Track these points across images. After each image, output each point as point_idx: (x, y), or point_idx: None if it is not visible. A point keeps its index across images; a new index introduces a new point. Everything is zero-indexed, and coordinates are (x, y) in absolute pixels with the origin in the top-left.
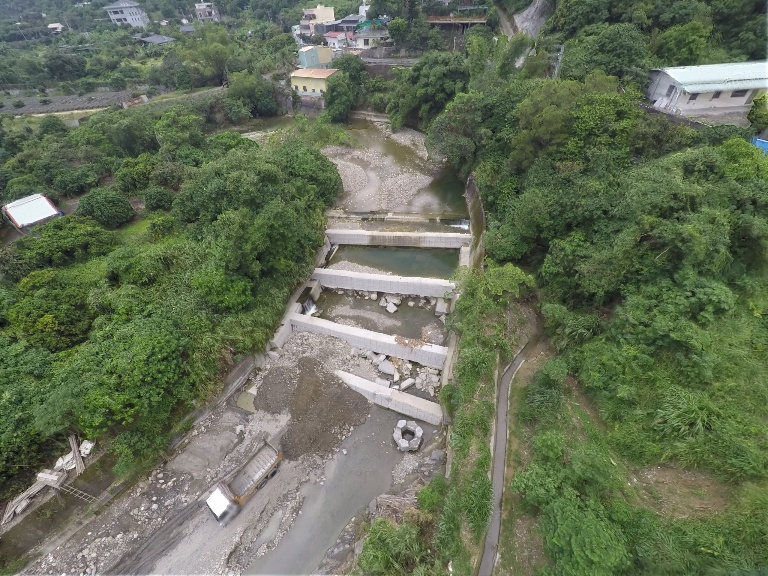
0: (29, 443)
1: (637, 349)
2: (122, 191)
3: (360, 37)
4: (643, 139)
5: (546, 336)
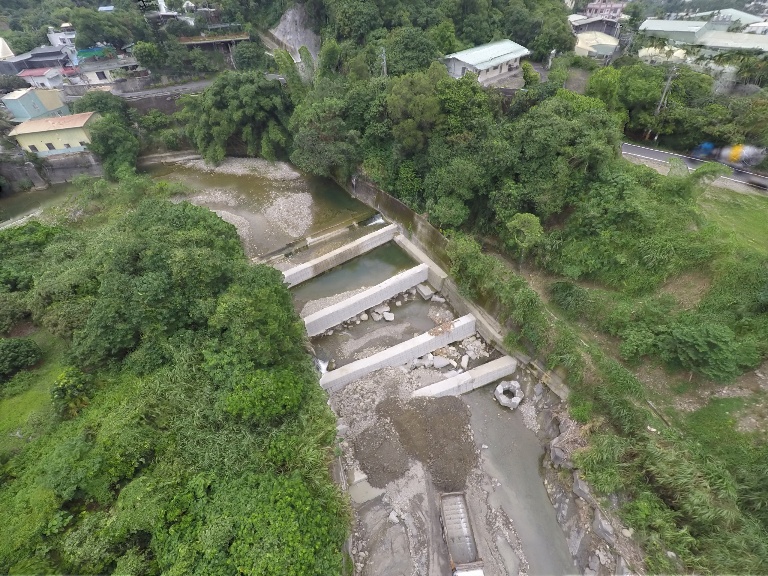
0: None
1: (610, 230)
2: None
3: (88, 70)
4: (497, 104)
5: (520, 264)
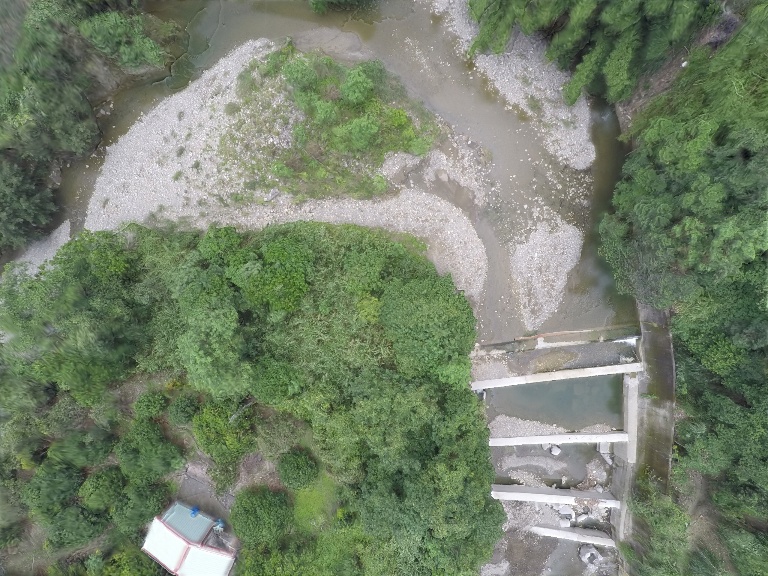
0: None
1: None
2: None
3: None
4: None
5: None
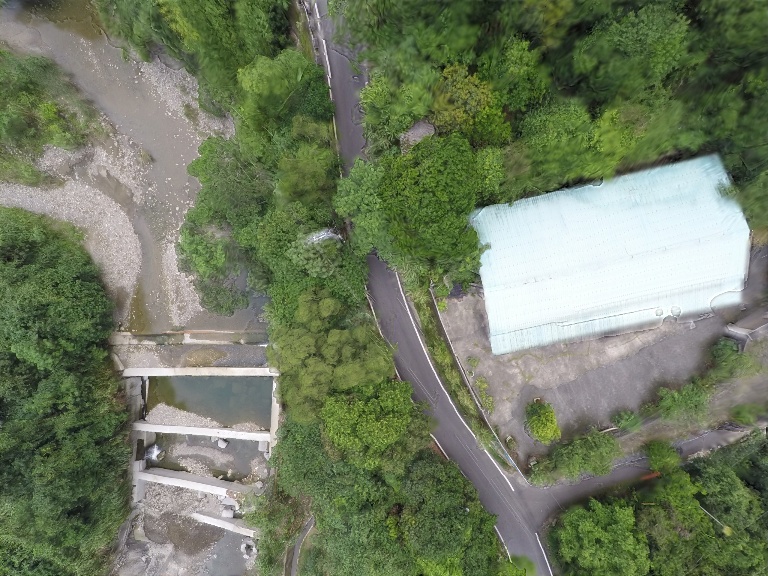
0: None
1: None
2: None
3: None
4: None
5: None
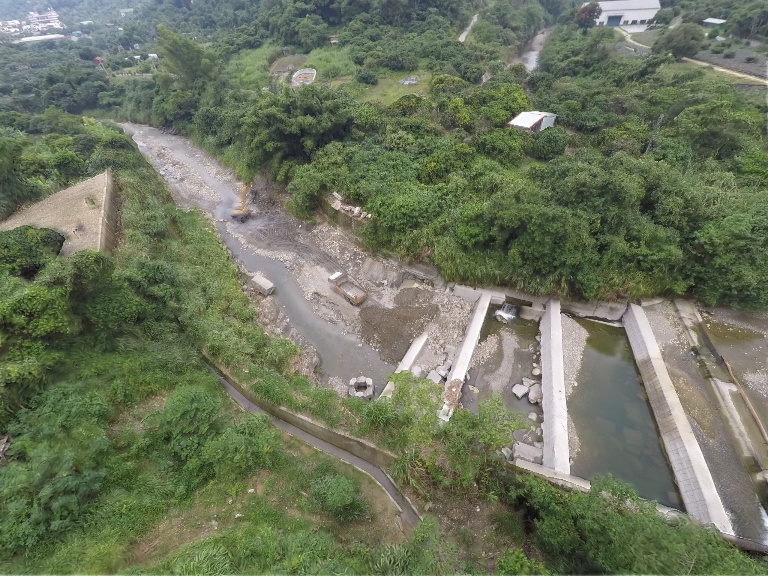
0: None
1: (295, 569)
2: (590, 143)
3: None
4: None
5: None
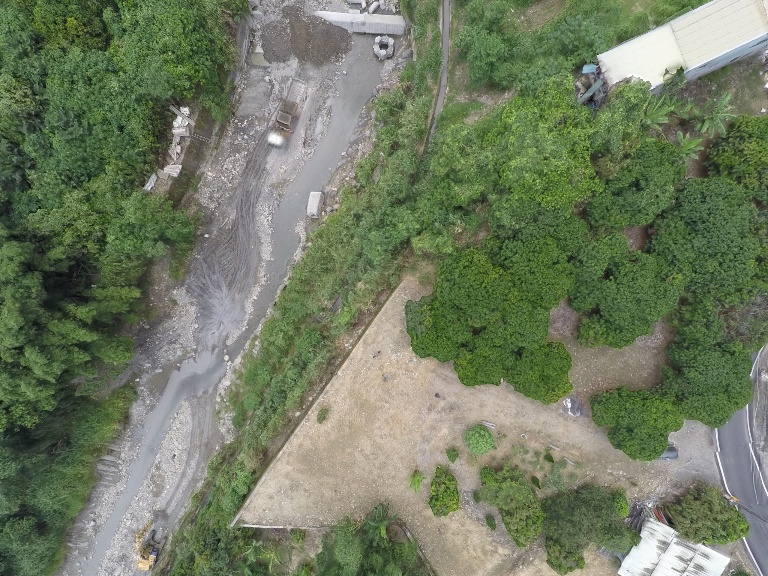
0: (153, 114)
1: None
2: None
3: None
4: None
5: None
